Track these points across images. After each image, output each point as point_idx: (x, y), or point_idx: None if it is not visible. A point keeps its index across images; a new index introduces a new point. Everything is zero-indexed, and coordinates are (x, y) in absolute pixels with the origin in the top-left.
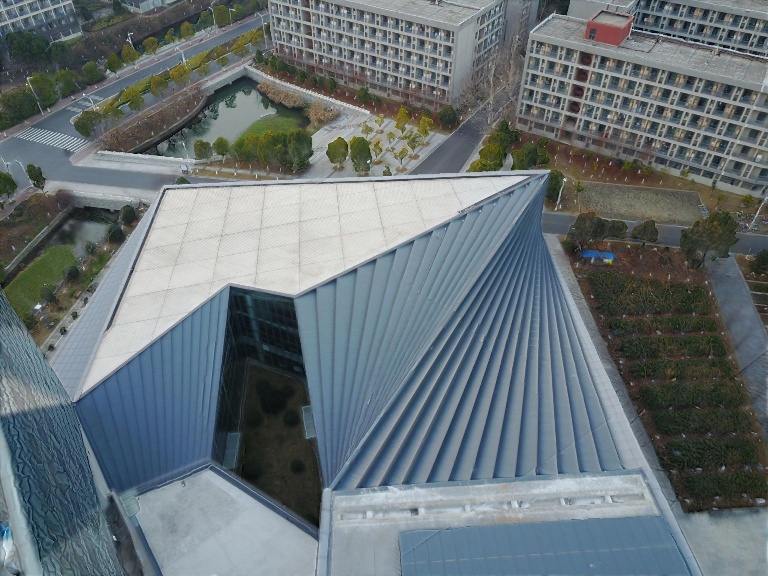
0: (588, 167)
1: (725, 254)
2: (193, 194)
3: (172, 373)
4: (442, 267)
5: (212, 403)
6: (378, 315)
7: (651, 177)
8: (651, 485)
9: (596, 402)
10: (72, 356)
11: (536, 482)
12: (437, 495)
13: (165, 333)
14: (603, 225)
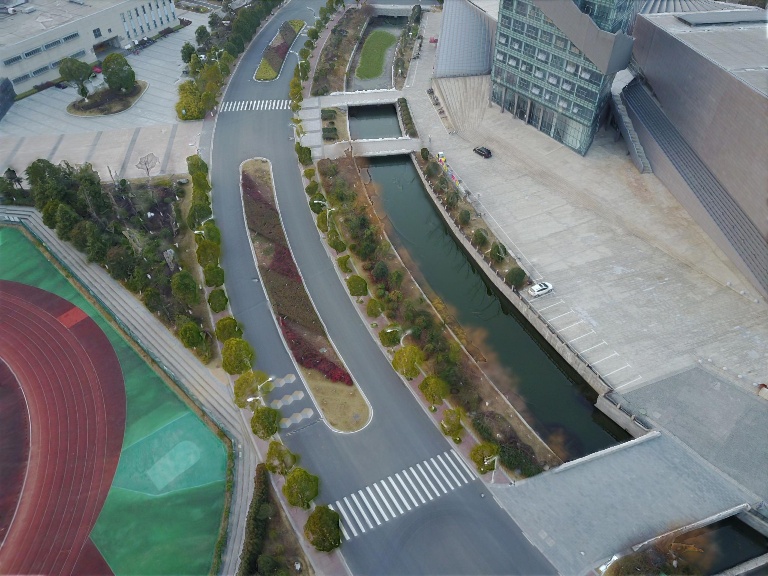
0: None
1: None
2: None
3: None
4: None
5: None
6: None
7: None
8: (760, 9)
9: (728, 5)
10: (450, 42)
11: None
12: (681, 13)
13: None
14: None
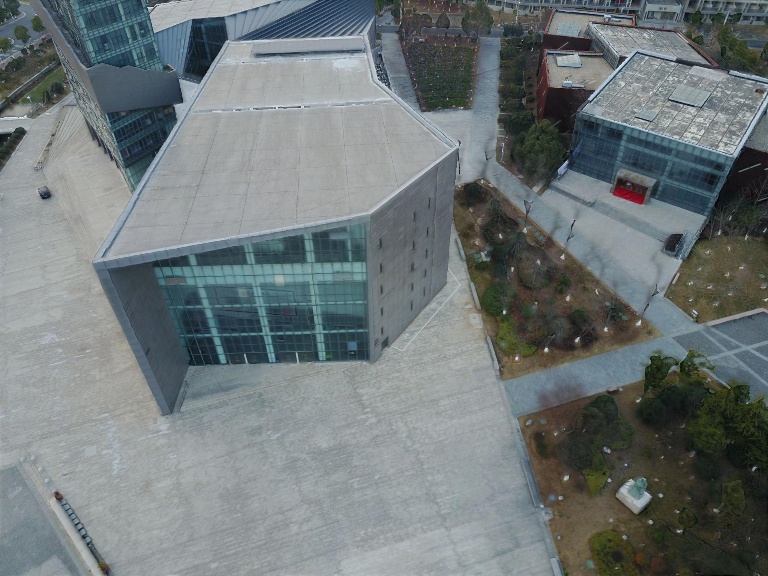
0: (428, 5)
1: (489, 32)
2: (174, 4)
3: (163, 46)
4: (302, 3)
5: (183, 58)
6: (266, 19)
7: (466, 9)
8: None
9: None
10: None
11: (317, 38)
12: (274, 40)
13: (159, 31)
14: (416, 17)
